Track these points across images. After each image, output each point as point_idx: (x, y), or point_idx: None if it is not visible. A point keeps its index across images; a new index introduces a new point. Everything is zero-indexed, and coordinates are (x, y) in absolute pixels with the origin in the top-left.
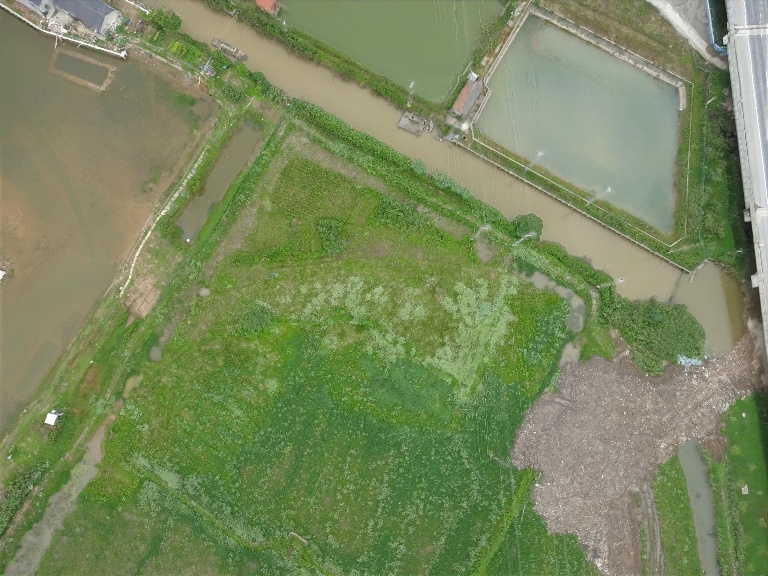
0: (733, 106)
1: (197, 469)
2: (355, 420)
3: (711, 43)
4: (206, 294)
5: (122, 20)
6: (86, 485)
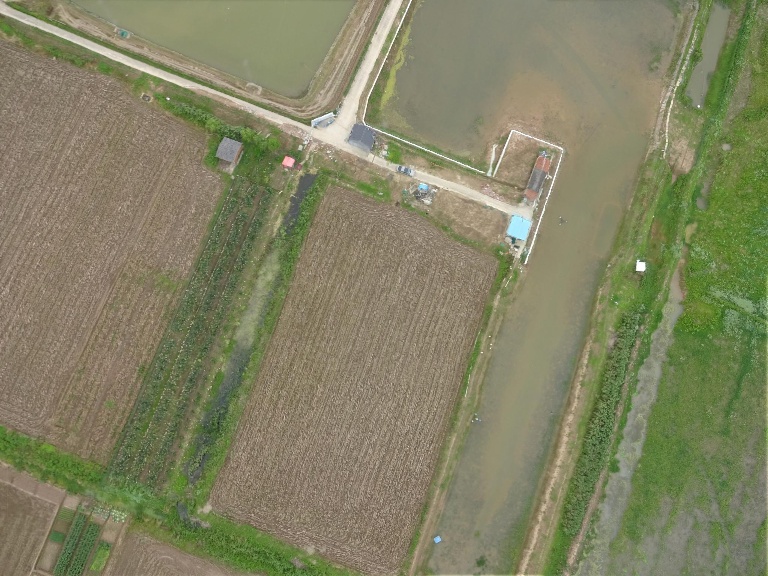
0: None
1: (763, 294)
2: None
3: None
4: (727, 149)
5: None
6: (677, 321)
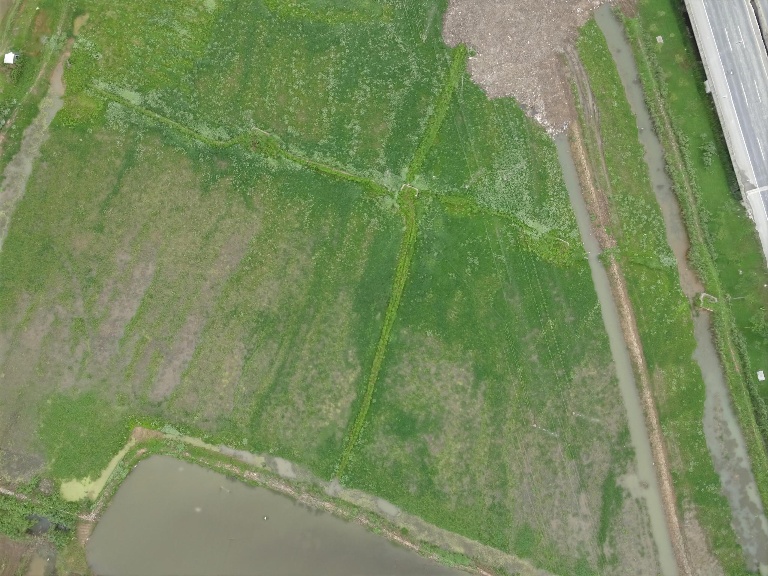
0: None
1: (155, 86)
2: (293, 24)
3: None
4: None
5: None
6: (55, 116)
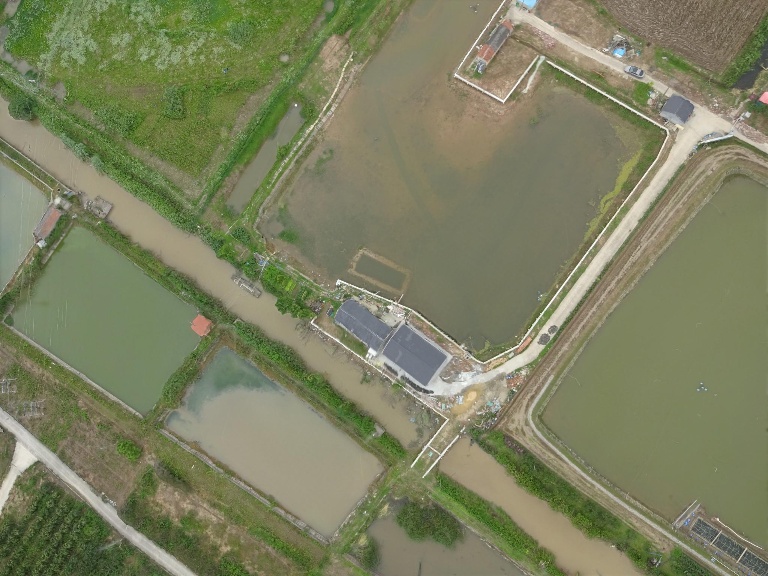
0: None
1: None
2: None
3: None
4: (284, 57)
5: None
6: None
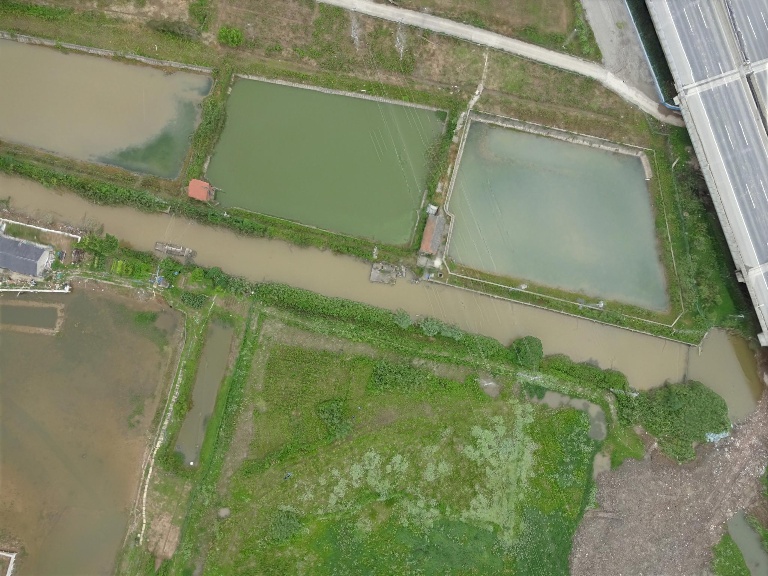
0: (700, 168)
1: None
2: None
3: (661, 102)
4: (226, 514)
5: (55, 254)
6: None
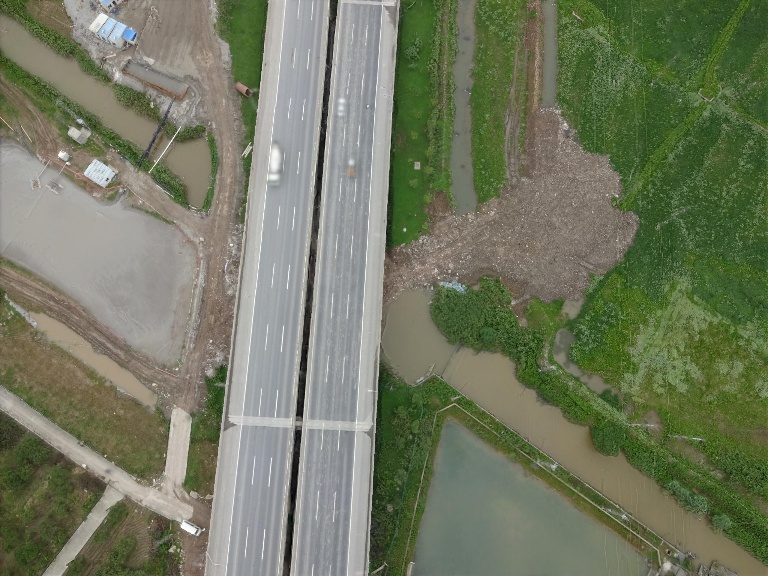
0: None
1: None
2: None
3: None
4: None
5: None
6: None
